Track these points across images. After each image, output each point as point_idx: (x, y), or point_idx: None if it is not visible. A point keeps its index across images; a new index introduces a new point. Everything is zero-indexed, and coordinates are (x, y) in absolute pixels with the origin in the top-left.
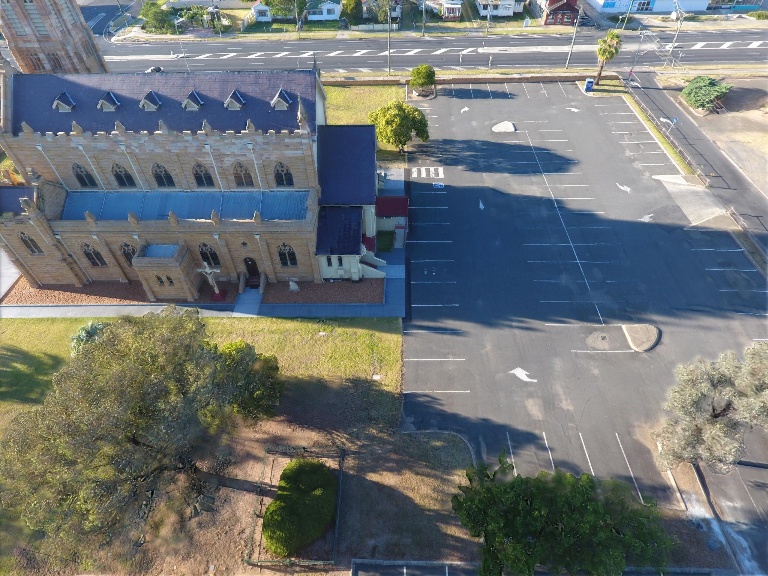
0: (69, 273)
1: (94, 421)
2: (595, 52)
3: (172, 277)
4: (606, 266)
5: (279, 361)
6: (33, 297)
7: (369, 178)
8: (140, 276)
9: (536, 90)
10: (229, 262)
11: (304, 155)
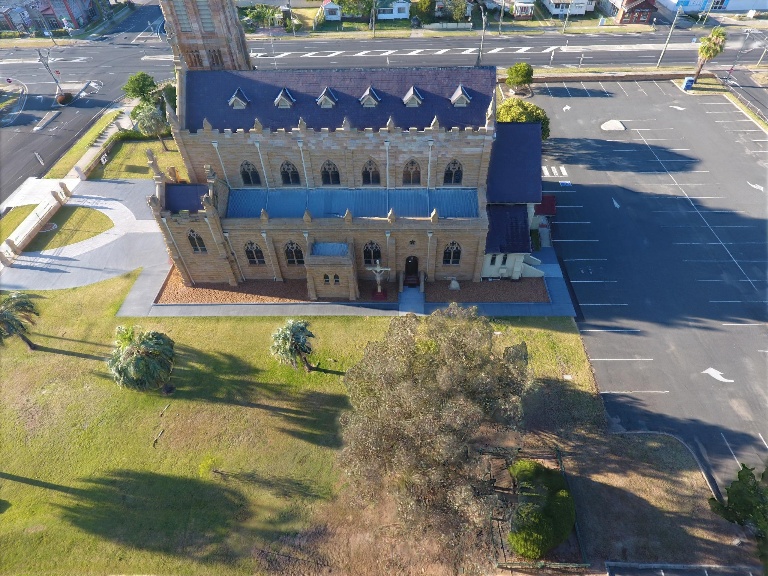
0: (228, 271)
1: (464, 421)
2: (681, 51)
3: (341, 276)
4: (765, 265)
5: None
6: (189, 296)
7: (535, 176)
8: (309, 274)
9: (633, 88)
10: (393, 261)
11: (482, 152)
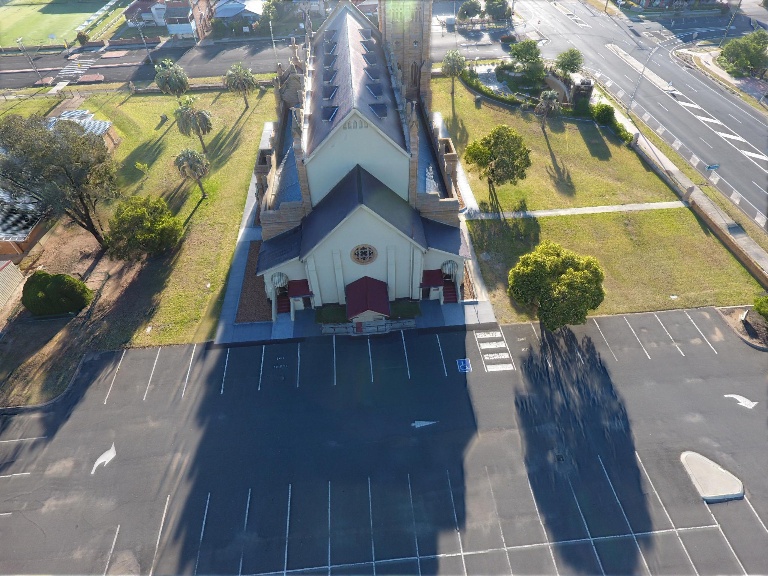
0: None
1: None
2: None
3: None
4: None
5: (187, 265)
6: None
7: (318, 238)
8: None
9: None
10: None
11: None
